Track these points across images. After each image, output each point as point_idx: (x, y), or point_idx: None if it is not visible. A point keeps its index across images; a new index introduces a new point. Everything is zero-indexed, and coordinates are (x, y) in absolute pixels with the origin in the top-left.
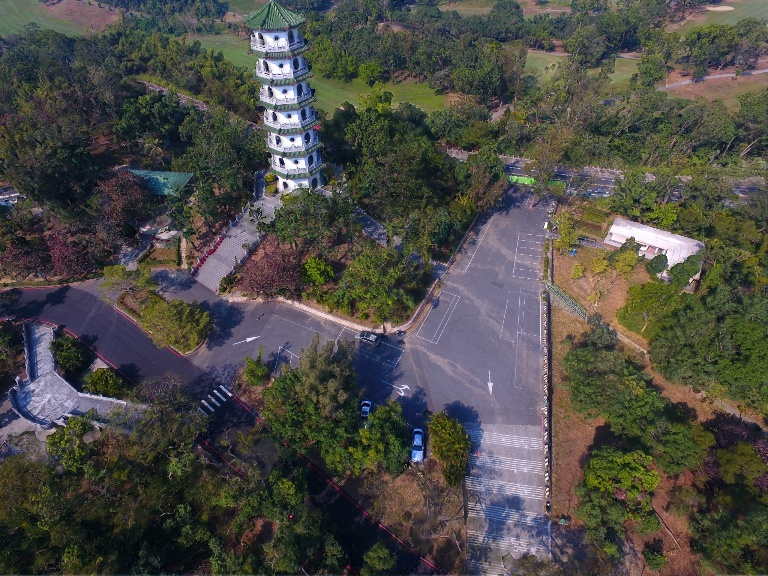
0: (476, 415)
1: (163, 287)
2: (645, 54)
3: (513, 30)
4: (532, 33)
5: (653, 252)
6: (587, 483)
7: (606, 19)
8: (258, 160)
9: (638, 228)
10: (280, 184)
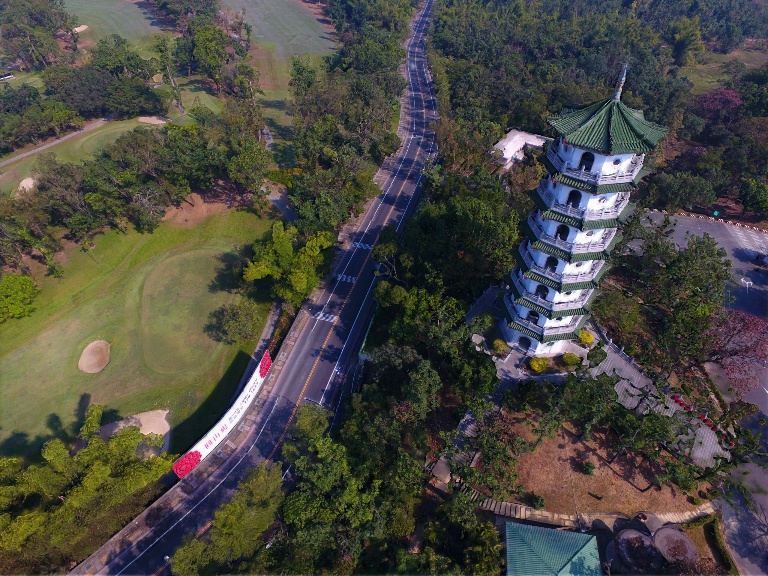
0: (738, 249)
1: (763, 533)
2: (205, 74)
3: (16, 130)
4: (46, 120)
5: (517, 152)
6: (767, 206)
7: (133, 61)
8: (499, 381)
9: (505, 146)
10: (559, 346)
